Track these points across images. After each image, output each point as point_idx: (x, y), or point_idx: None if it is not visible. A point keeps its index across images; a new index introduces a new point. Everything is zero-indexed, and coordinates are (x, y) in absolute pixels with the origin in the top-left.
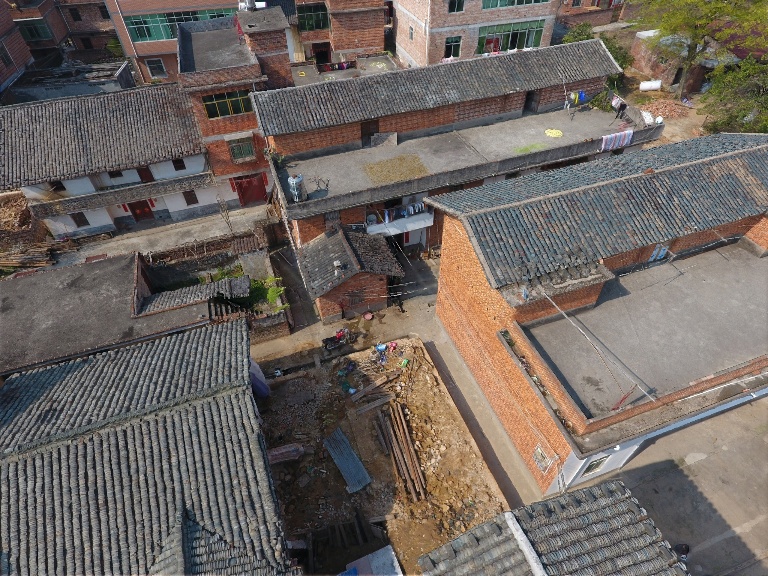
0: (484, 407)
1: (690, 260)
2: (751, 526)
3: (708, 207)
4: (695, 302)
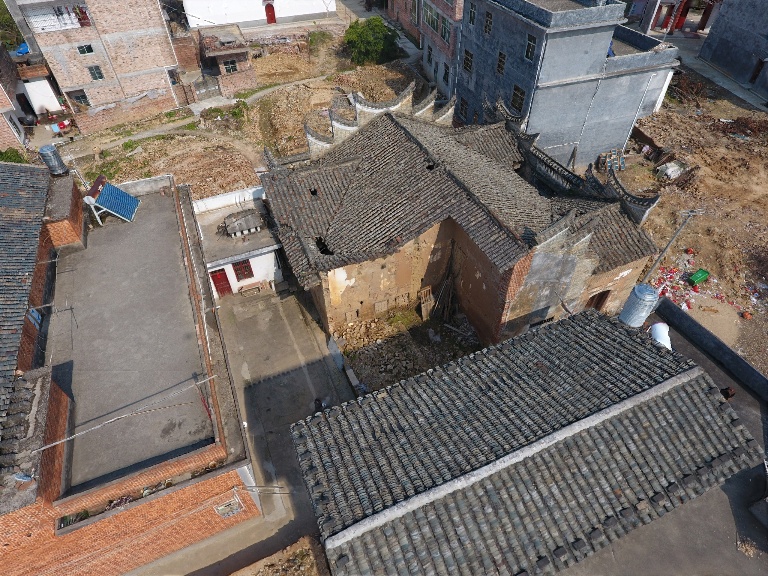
0: (141, 575)
1: (58, 297)
2: (301, 354)
3: (7, 254)
4: (111, 311)
